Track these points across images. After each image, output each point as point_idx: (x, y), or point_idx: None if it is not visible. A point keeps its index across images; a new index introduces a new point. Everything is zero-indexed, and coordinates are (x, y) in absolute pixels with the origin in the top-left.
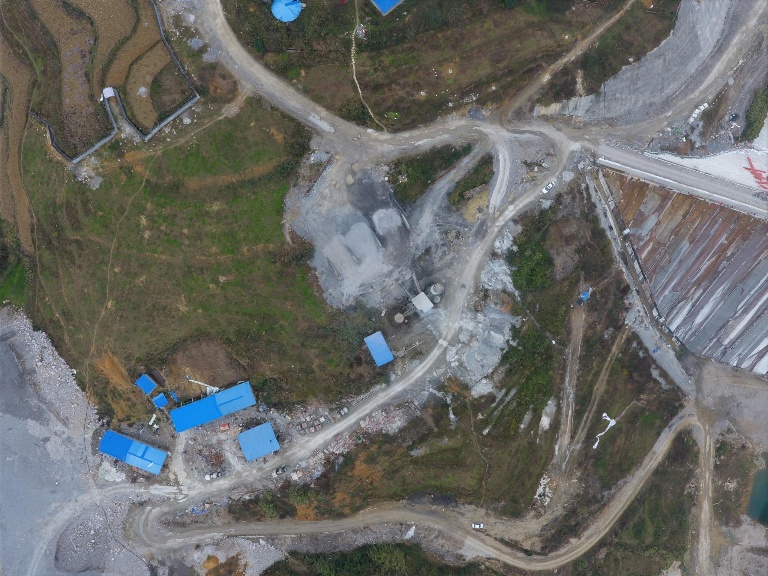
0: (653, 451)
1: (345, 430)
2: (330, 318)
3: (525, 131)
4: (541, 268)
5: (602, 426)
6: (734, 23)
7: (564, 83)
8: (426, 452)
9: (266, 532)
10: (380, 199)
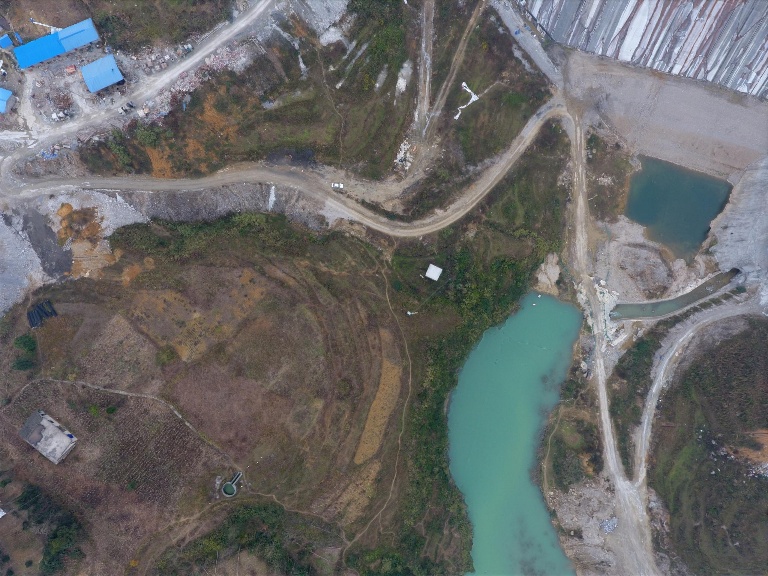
0: (521, 136)
1: (191, 68)
2: None
3: None
4: None
5: (463, 98)
6: None
7: None
8: (279, 105)
9: (122, 187)
10: None
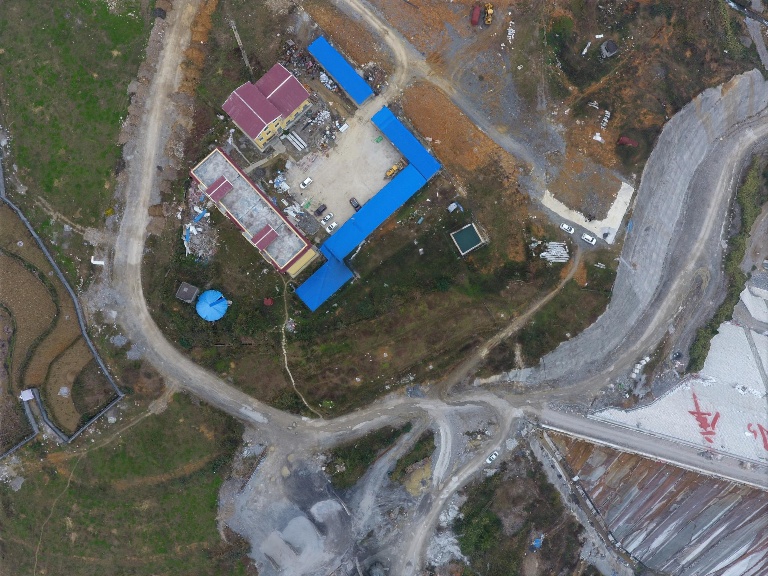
0: None
1: None
2: None
3: (466, 402)
4: (489, 531)
5: None
6: (672, 268)
7: (502, 359)
8: None
9: None
10: (318, 491)
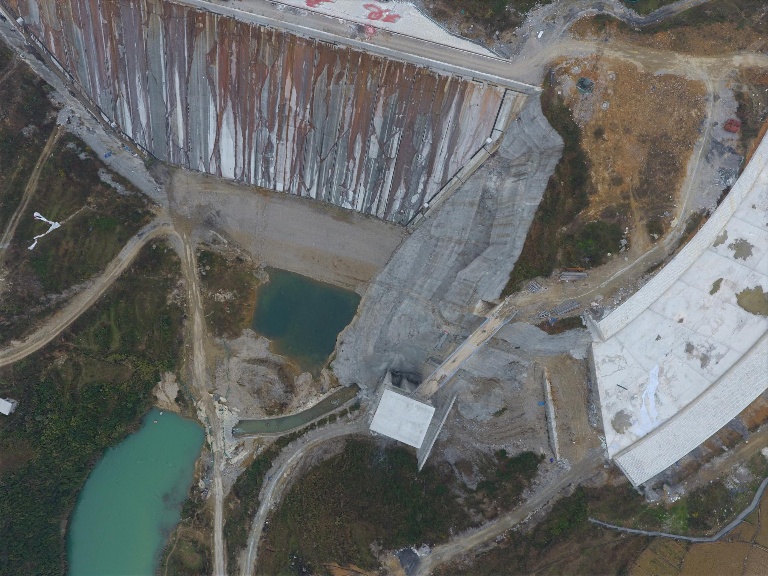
0: (118, 258)
1: None
2: None
3: None
4: None
5: (38, 227)
6: None
7: None
8: None
9: None
10: None
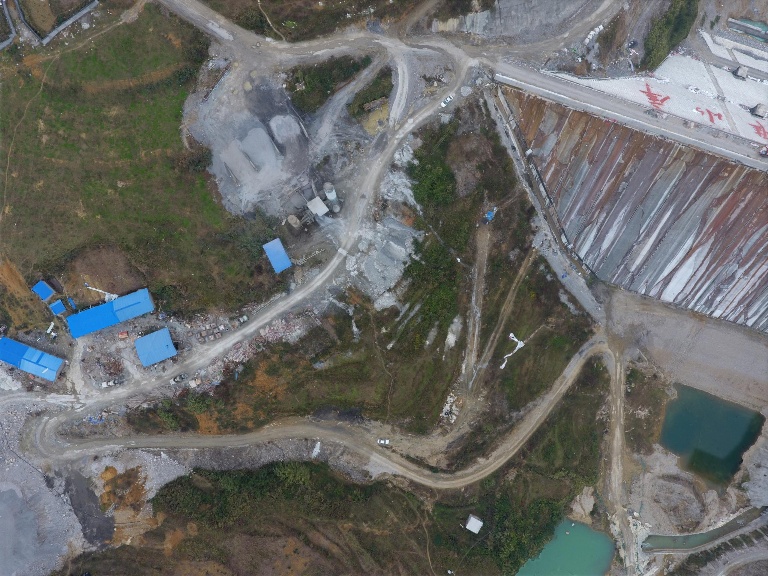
0: (563, 376)
1: (245, 339)
2: (228, 224)
3: (424, 46)
4: (442, 183)
5: (510, 347)
6: None
7: None
8: (330, 366)
9: (168, 445)
10: (277, 106)
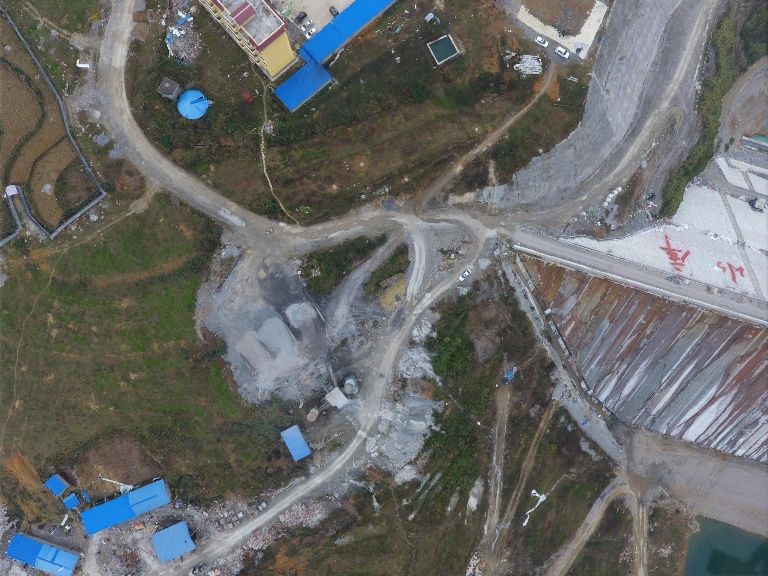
0: (586, 523)
1: (264, 525)
2: (245, 413)
3: (440, 220)
4: (462, 353)
5: (532, 503)
6: (646, 106)
7: (476, 174)
8: (351, 540)
9: None
10: (293, 293)
